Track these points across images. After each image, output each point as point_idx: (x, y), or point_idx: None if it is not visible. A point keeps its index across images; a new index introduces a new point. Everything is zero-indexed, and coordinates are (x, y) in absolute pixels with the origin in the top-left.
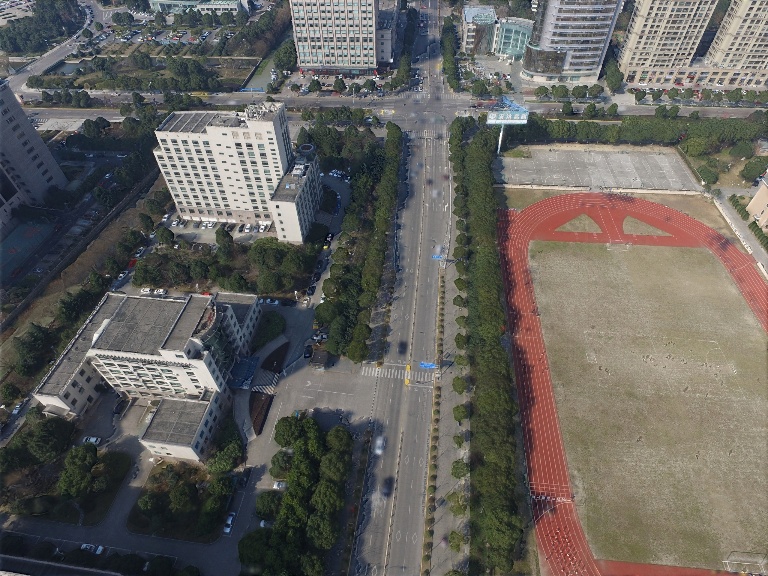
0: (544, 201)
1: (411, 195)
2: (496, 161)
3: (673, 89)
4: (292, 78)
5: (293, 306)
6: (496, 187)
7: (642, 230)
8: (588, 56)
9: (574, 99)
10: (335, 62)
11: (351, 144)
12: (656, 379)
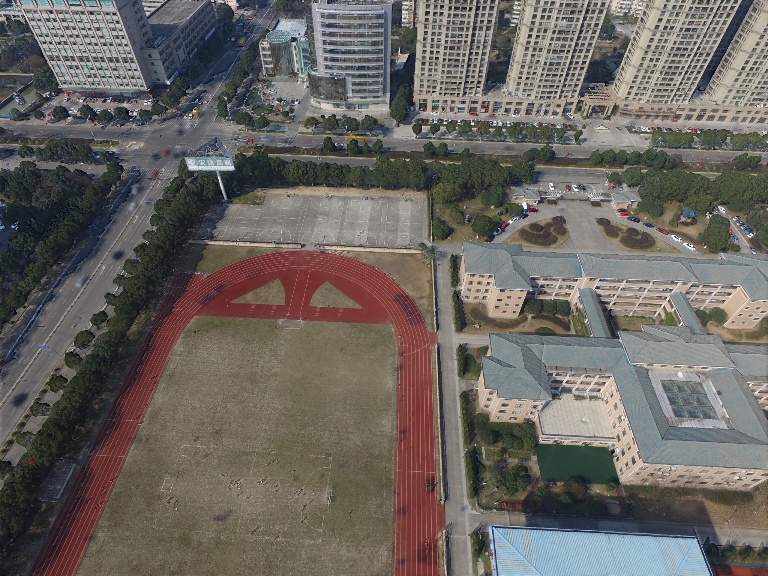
0: (242, 262)
1: (93, 254)
2: (219, 209)
3: (449, 122)
4: (54, 101)
5: None
6: (198, 244)
7: (331, 301)
8: (369, 83)
9: (353, 131)
10: (100, 84)
11: (40, 191)
12: (228, 515)
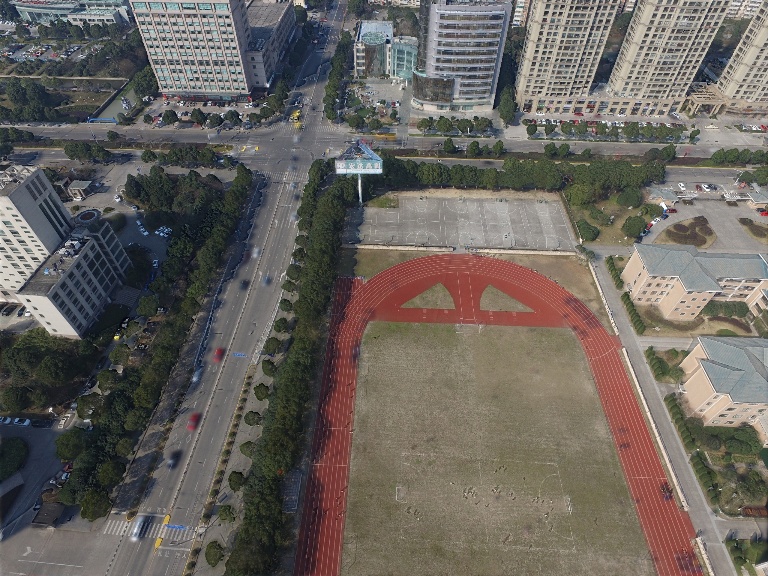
0: (398, 266)
1: (245, 260)
2: (356, 213)
3: (566, 123)
4: (154, 105)
5: (47, 427)
6: (347, 248)
7: (501, 304)
8: (478, 84)
9: None
10: (202, 87)
11: (182, 196)
12: (473, 525)
